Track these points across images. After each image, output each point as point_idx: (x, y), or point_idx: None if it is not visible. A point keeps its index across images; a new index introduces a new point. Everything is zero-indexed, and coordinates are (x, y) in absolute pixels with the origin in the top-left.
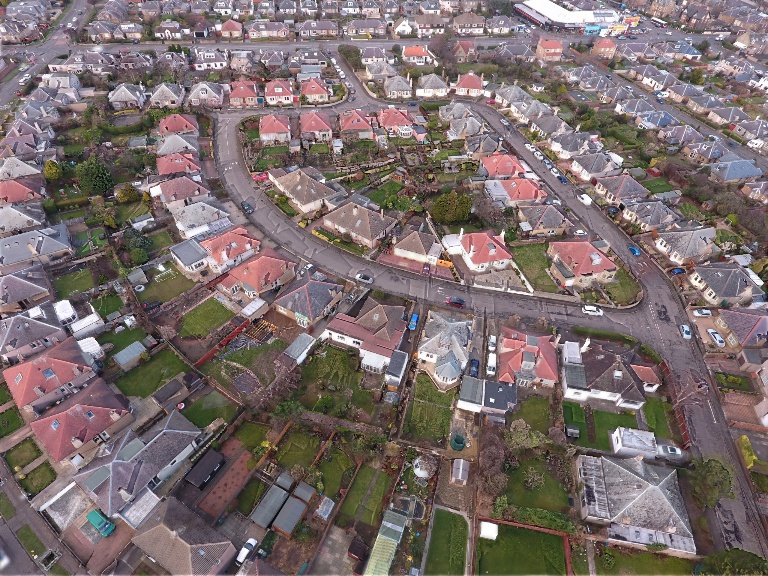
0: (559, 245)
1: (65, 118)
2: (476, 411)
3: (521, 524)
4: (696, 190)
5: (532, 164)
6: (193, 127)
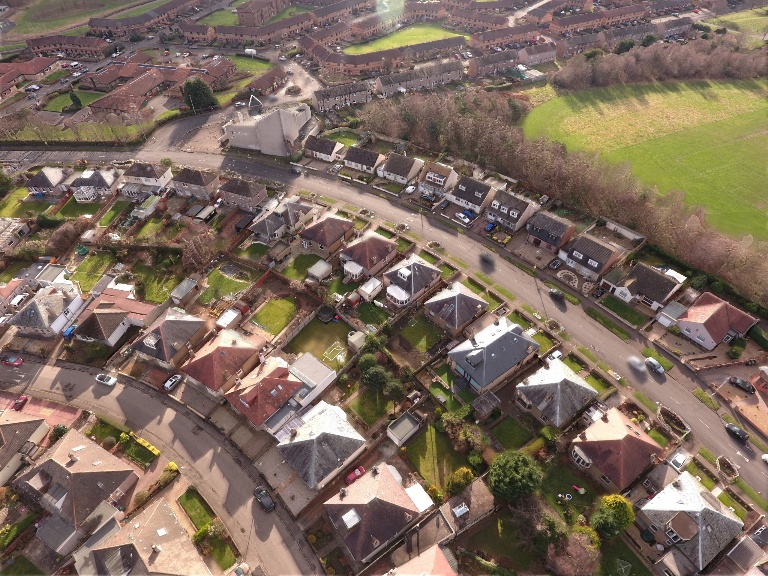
0: None
1: None
2: None
3: None
4: None
5: None
6: None
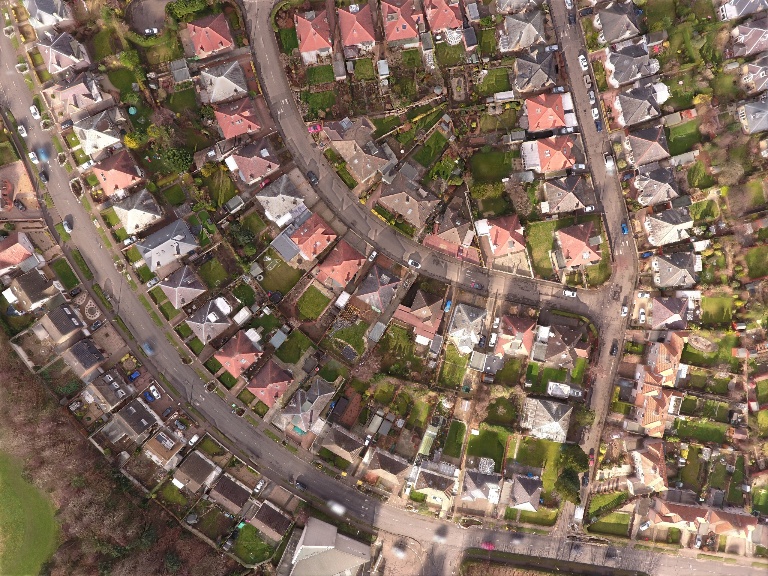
0: (564, 237)
1: (75, 7)
2: None
3: (490, 430)
4: (713, 152)
5: (577, 96)
6: (228, 43)
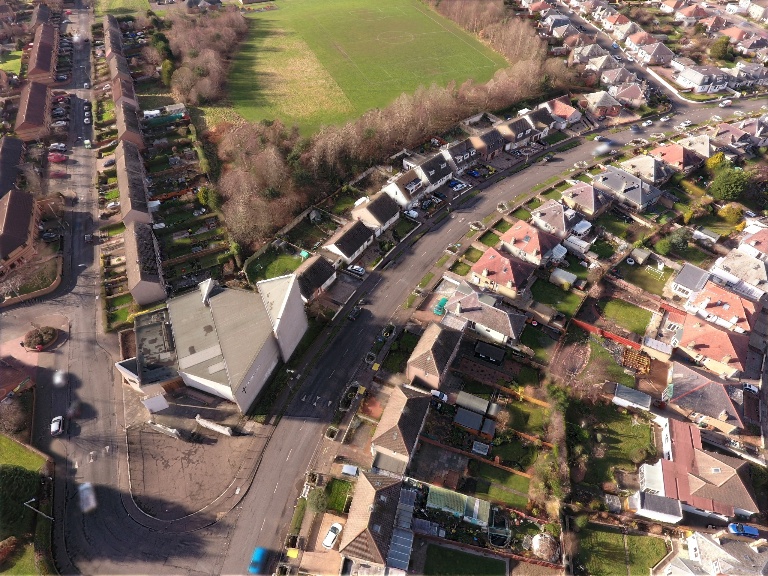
0: None
1: None
2: None
3: None
4: None
5: None
6: None
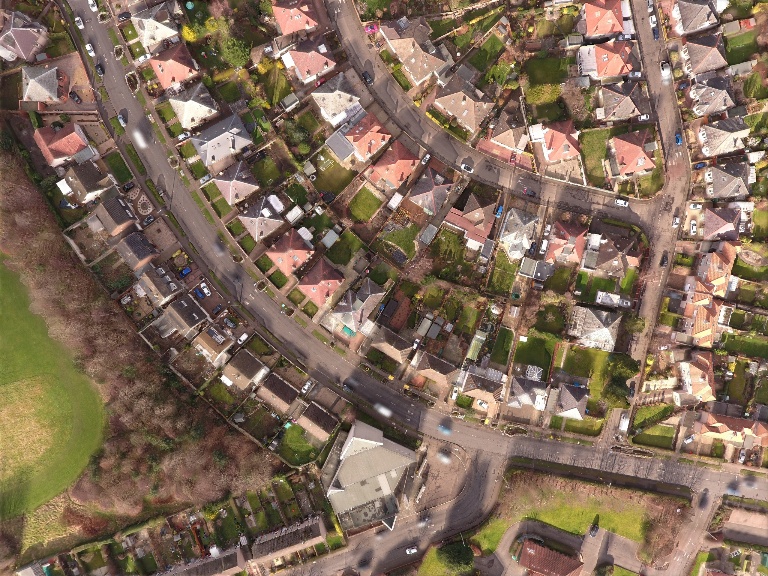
0: (619, 143)
1: None
2: (528, 277)
3: (539, 337)
4: None
5: (635, 3)
6: None
